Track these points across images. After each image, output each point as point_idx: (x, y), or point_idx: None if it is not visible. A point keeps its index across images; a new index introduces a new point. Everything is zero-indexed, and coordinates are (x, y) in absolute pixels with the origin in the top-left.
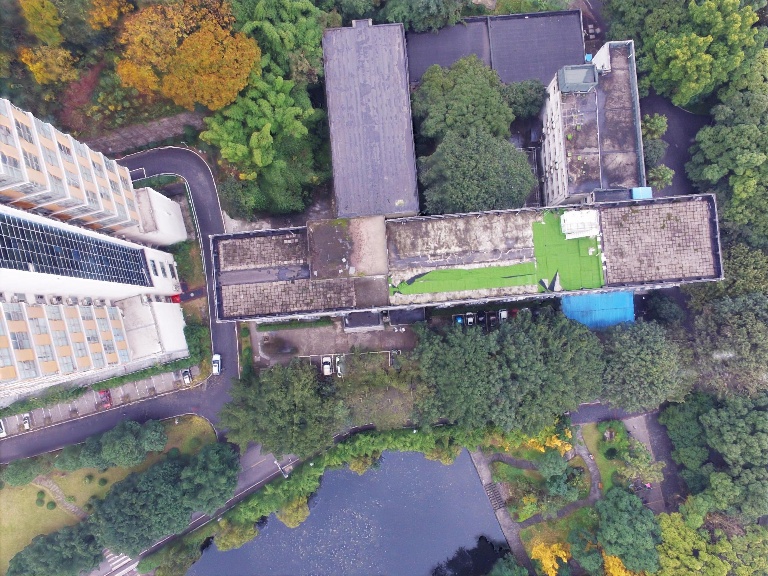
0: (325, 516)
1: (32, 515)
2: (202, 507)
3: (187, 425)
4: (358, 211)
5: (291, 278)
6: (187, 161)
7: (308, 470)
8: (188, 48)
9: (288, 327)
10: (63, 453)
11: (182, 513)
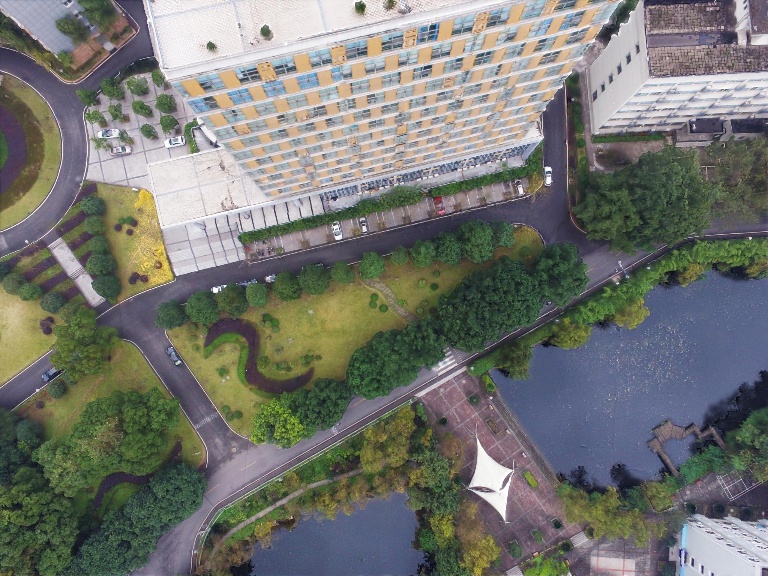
0: (641, 331)
1: (364, 317)
2: (560, 296)
3: (517, 234)
4: None
5: (711, 44)
6: None
7: (645, 274)
8: None
9: (623, 139)
10: (418, 245)
11: (537, 303)
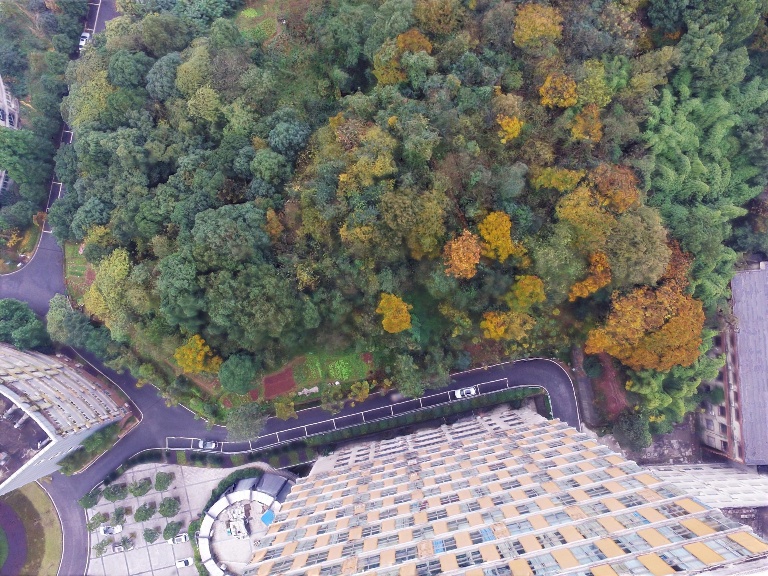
0: None
1: None
2: None
3: None
4: (766, 458)
5: None
6: (549, 372)
7: None
8: (674, 331)
9: None
10: None
11: None
